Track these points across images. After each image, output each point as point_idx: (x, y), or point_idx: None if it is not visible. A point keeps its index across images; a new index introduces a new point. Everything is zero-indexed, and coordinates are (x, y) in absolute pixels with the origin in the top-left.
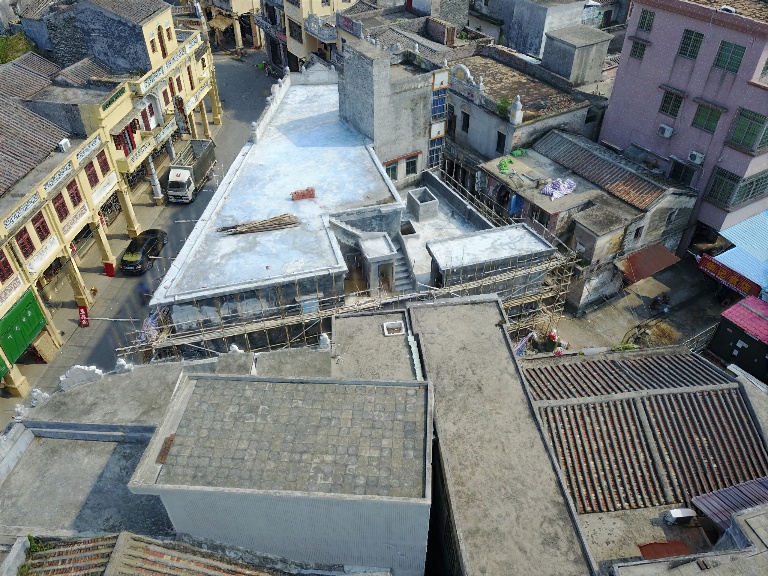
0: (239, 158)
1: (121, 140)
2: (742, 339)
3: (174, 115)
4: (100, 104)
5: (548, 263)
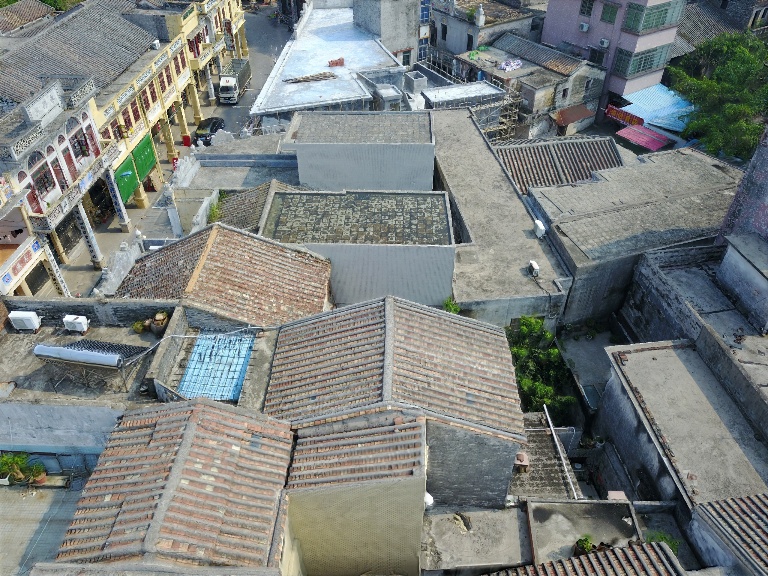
0: (286, 48)
1: (192, 45)
2: (629, 148)
3: (223, 35)
4: (182, 15)
5: (502, 102)
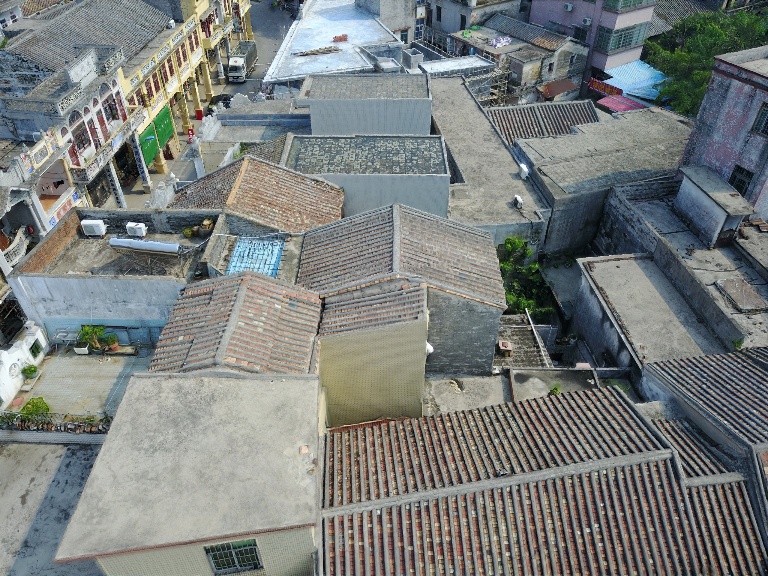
0: (293, 26)
1: (205, 26)
2: None
3: (232, 17)
4: None
5: (492, 73)
